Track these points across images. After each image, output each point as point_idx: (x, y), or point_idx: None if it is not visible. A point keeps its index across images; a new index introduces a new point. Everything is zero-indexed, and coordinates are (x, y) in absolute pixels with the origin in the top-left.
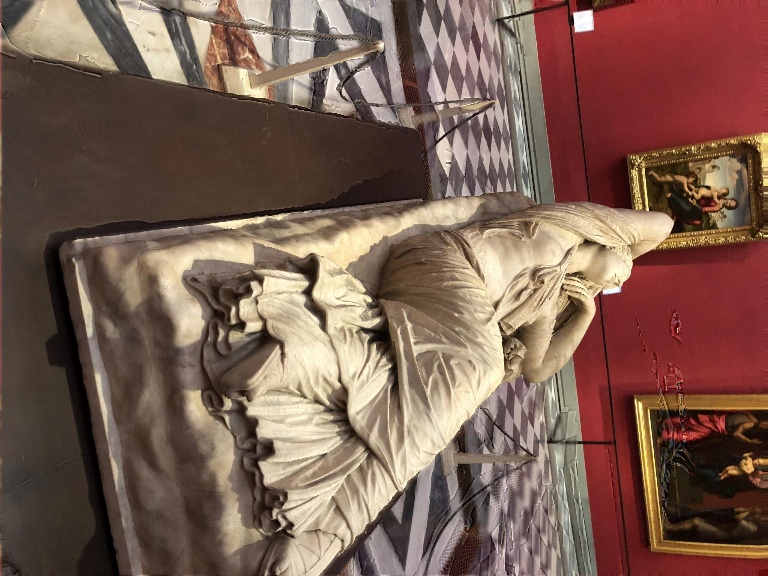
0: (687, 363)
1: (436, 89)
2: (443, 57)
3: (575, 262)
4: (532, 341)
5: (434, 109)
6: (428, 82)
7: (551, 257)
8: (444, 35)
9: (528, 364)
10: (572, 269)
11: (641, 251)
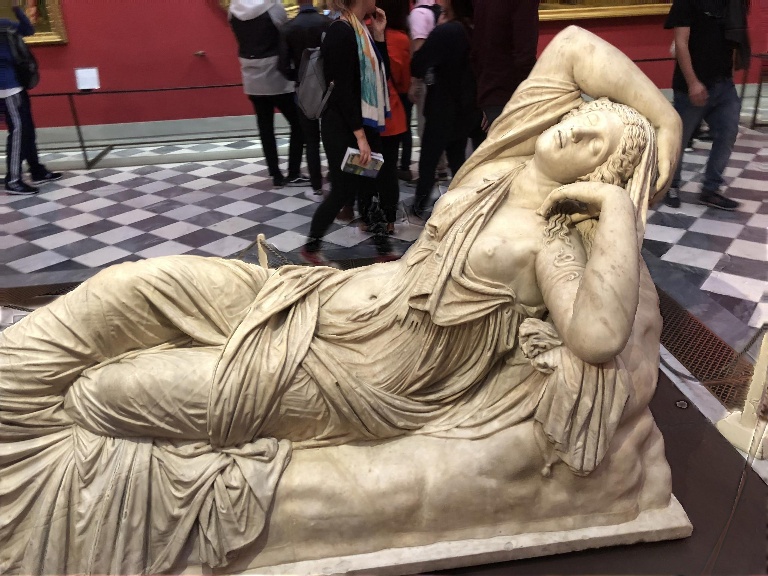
0: (765, 37)
1: (735, 284)
2: (748, 259)
3: (522, 182)
4: (548, 305)
5: (729, 297)
6: (704, 284)
7: (440, 203)
8: (751, 247)
9: (564, 337)
10: (530, 190)
11: (602, 81)
